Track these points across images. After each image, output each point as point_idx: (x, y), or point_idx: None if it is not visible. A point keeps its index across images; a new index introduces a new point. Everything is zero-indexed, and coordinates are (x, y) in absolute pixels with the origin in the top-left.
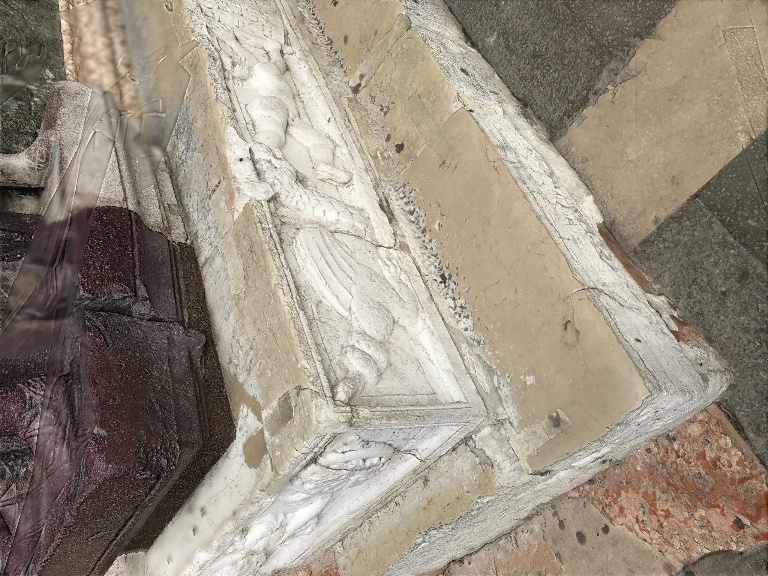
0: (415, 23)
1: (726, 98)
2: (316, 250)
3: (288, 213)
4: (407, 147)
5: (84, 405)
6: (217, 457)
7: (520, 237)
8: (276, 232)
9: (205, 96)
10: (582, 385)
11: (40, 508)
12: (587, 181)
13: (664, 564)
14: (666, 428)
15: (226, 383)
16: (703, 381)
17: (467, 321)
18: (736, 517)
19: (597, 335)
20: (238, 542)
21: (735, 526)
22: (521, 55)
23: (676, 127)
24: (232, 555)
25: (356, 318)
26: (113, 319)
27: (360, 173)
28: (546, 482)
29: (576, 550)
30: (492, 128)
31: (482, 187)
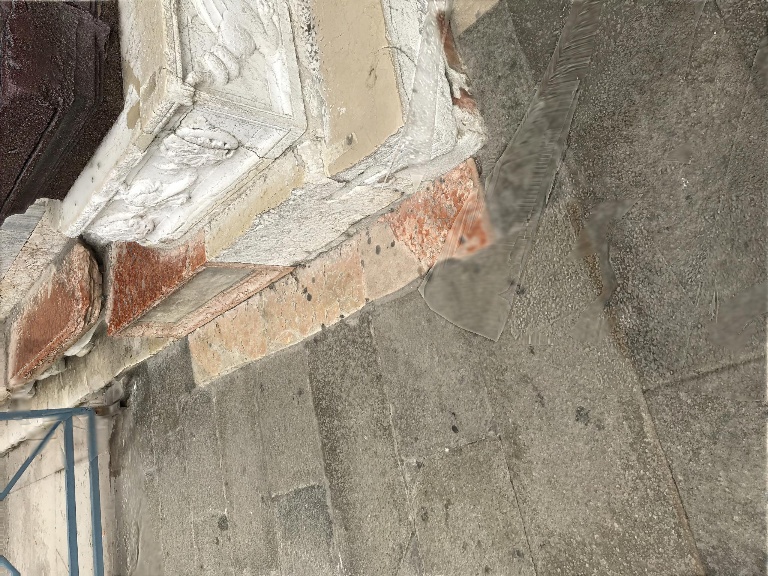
0: None
1: None
2: None
3: None
4: None
5: None
6: (111, 123)
7: (361, 0)
8: None
9: None
10: (369, 116)
11: None
12: None
13: (419, 267)
14: (439, 171)
15: (123, 68)
16: (458, 134)
17: (316, 63)
18: None
19: (386, 81)
20: (123, 191)
21: None
22: None
23: None
24: (125, 213)
25: (222, 35)
26: None
27: None
28: (348, 193)
29: (373, 258)
30: None
31: None
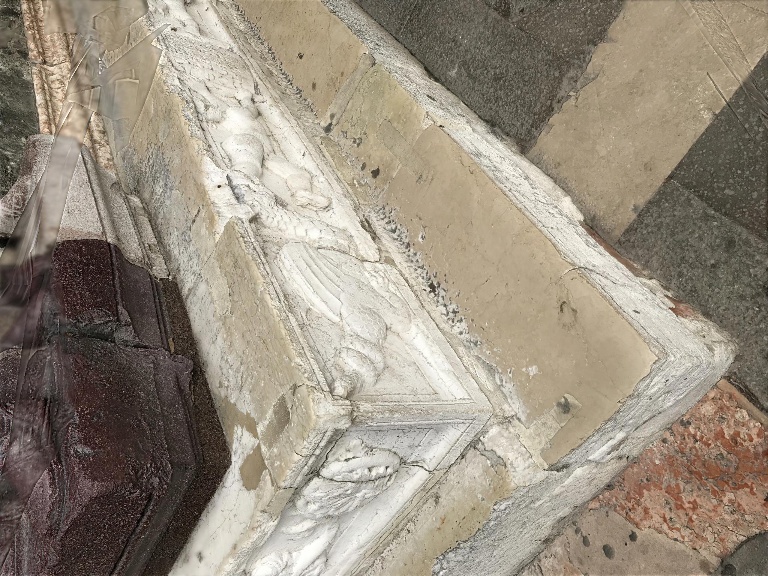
0: (379, 59)
1: (684, 82)
2: (301, 261)
3: (270, 233)
4: (383, 171)
5: (65, 384)
6: (213, 490)
7: (504, 231)
8: (259, 245)
9: (180, 136)
10: (587, 363)
11: (18, 490)
12: (562, 184)
13: (701, 562)
14: (679, 412)
15: (217, 408)
16: (708, 350)
17: (461, 325)
18: (767, 494)
19: (594, 310)
20: None
21: (767, 504)
22: (483, 81)
23: (641, 117)
24: None
25: (347, 323)
26: (95, 343)
27: (339, 197)
28: (564, 483)
29: (605, 566)
30: (464, 140)
31: (460, 192)
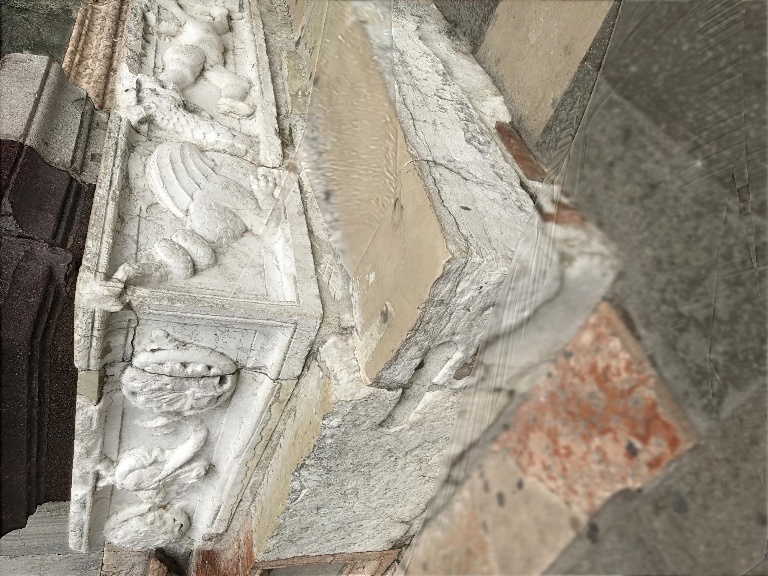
0: None
1: None
2: (166, 158)
3: (163, 135)
4: None
5: None
6: None
7: None
8: (124, 141)
9: None
10: (402, 266)
11: None
12: (499, 84)
13: None
14: None
15: None
16: None
17: None
18: None
19: (414, 204)
20: (104, 471)
21: None
22: None
23: None
24: (139, 504)
25: (191, 219)
26: None
27: (265, 105)
28: (416, 409)
29: None
30: None
31: None
